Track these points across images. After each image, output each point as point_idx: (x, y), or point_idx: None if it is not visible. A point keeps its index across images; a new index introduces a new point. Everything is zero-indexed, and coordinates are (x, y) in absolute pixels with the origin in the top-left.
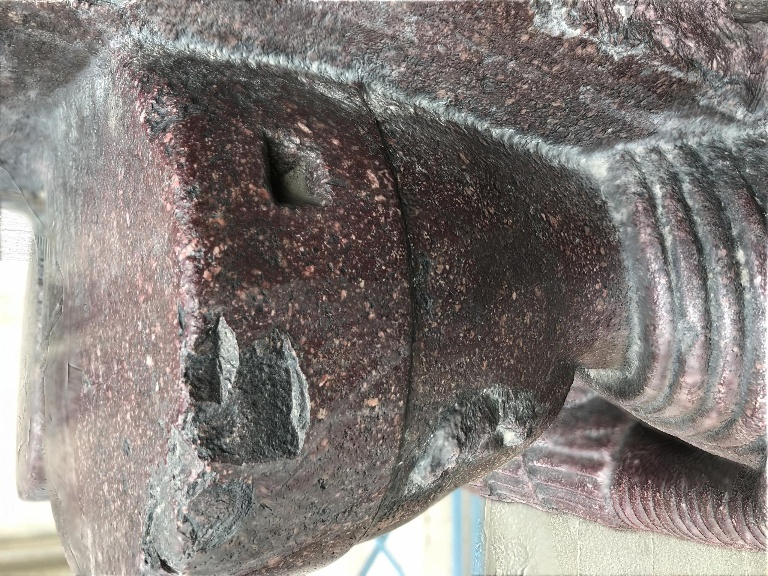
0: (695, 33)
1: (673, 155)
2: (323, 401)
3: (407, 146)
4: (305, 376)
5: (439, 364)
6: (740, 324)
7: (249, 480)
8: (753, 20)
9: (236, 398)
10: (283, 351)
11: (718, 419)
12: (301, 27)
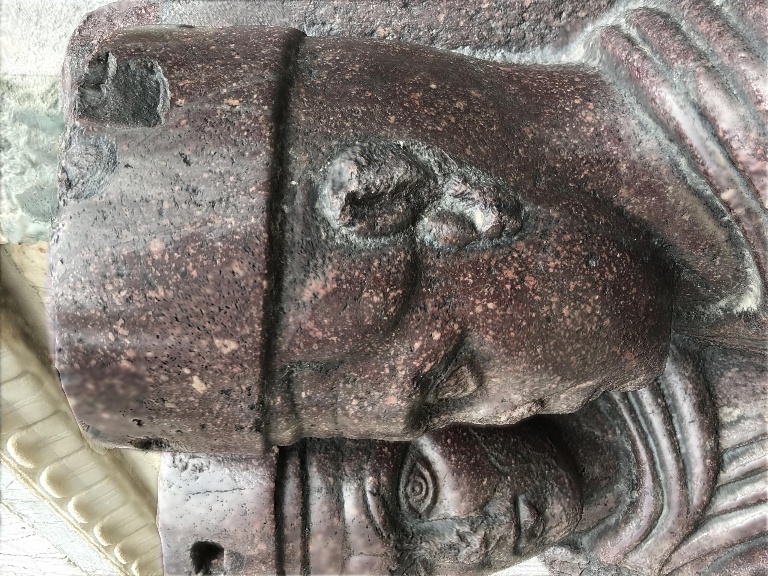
0: None
1: (643, 4)
2: (182, 95)
3: None
4: (167, 79)
5: (325, 105)
6: (734, 31)
7: (113, 141)
8: None
9: (111, 93)
10: (153, 70)
11: None
12: (251, 9)
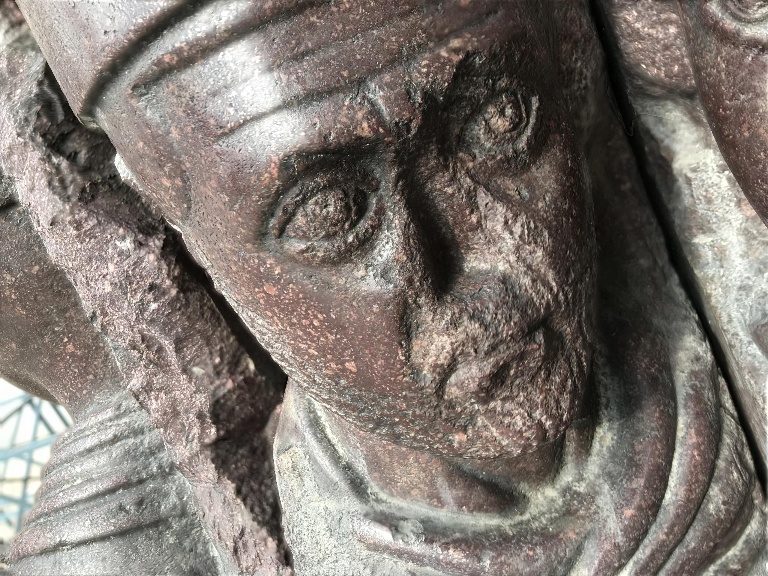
0: (164, 407)
1: None
2: None
3: (5, 230)
4: None
5: None
6: (47, 490)
7: None
8: (230, 463)
9: None
10: None
11: None
12: None
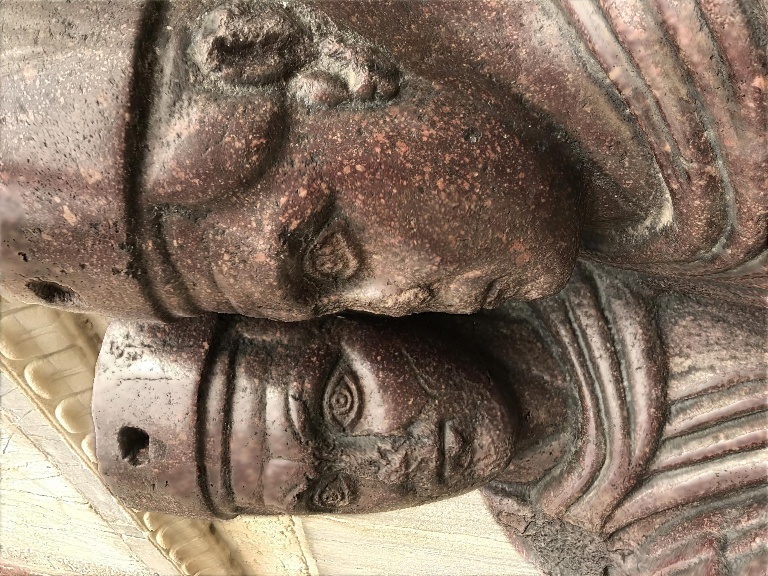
0: None
1: None
2: None
3: None
4: None
5: None
6: None
7: None
8: None
9: None
10: None
11: (687, 24)
12: None
